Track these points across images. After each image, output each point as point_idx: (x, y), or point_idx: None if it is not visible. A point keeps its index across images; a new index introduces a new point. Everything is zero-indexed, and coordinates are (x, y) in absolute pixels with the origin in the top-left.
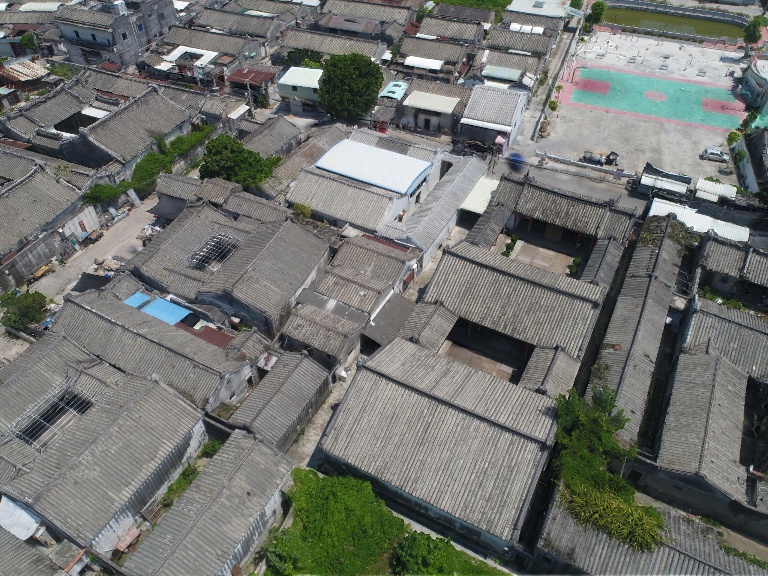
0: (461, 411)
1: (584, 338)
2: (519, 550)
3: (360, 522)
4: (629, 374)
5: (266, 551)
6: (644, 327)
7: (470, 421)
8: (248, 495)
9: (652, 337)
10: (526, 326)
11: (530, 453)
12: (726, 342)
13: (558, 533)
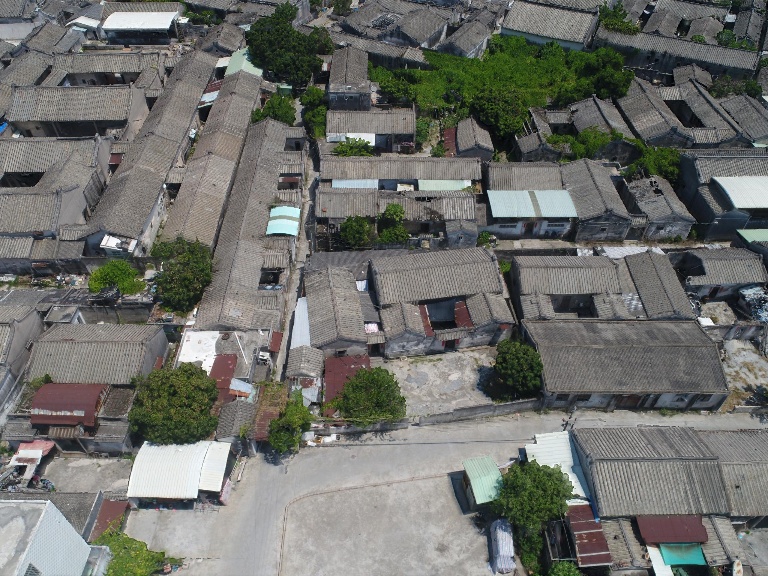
0: (560, 9)
1: (609, 4)
2: (586, 50)
3: (522, 43)
4: (629, 14)
5: (489, 46)
6: (636, 5)
7: (564, 12)
8: (478, 34)
9: (640, 9)
10: (582, 4)
11: (589, 17)
12: (673, 8)
13: (601, 35)
